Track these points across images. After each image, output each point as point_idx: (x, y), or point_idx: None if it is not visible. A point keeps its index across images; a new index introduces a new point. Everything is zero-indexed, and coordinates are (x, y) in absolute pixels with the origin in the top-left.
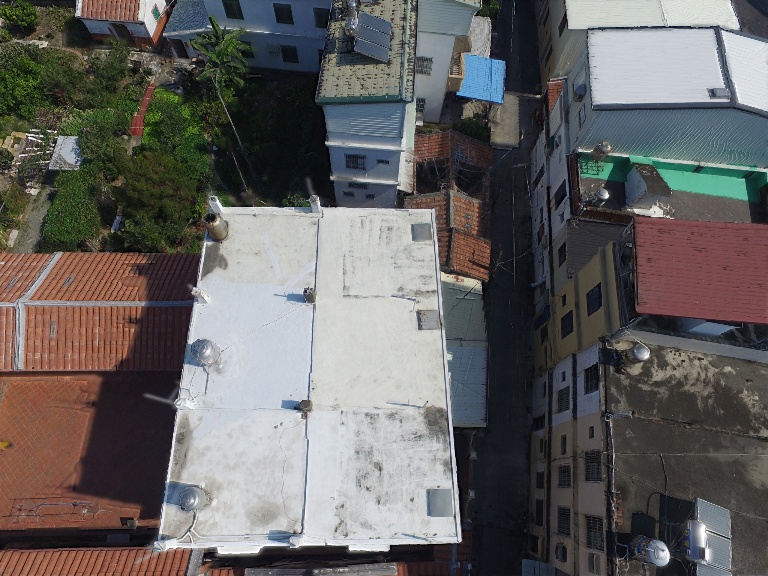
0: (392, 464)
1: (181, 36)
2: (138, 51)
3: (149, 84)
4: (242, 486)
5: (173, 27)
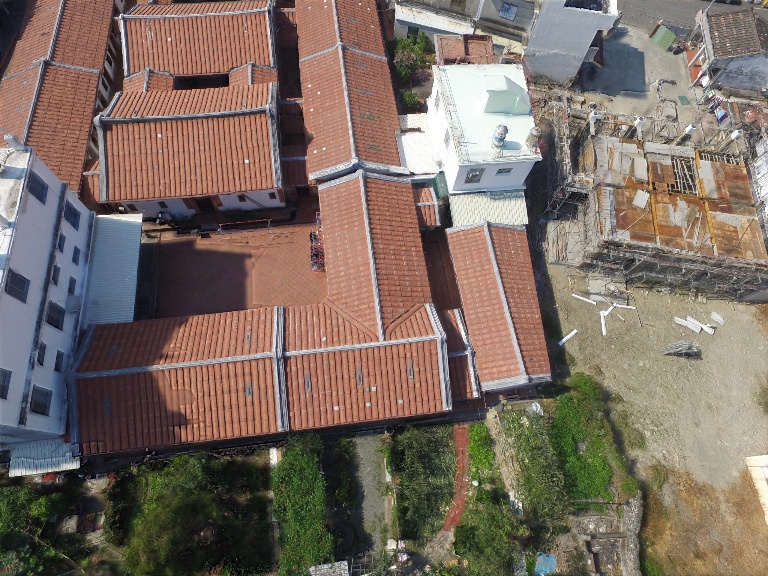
0: None
1: None
2: None
3: None
4: None
5: None
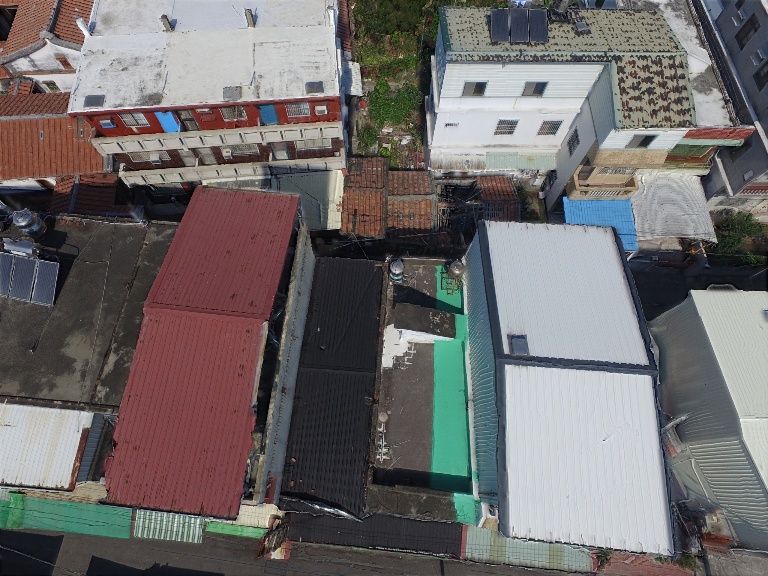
0: (125, 76)
1: None
2: None
3: None
4: (126, 8)
5: None
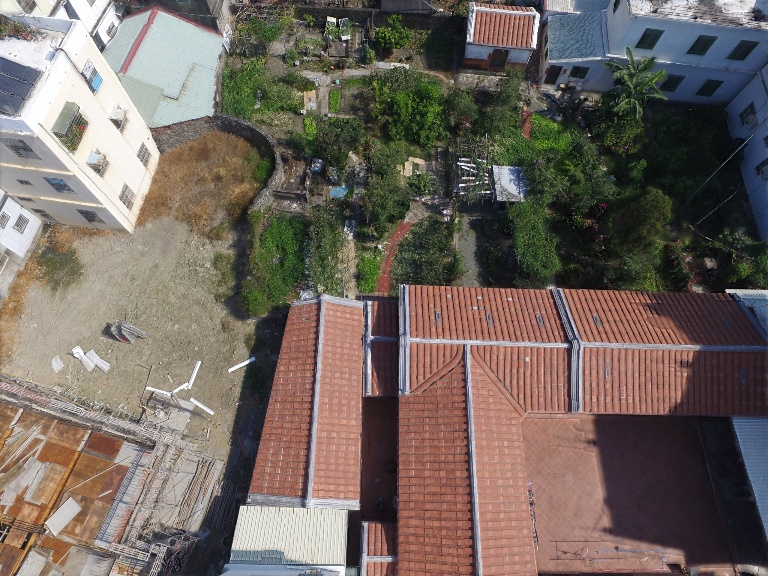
0: None
1: (568, 63)
2: (504, 76)
3: (523, 110)
4: None
5: (558, 54)
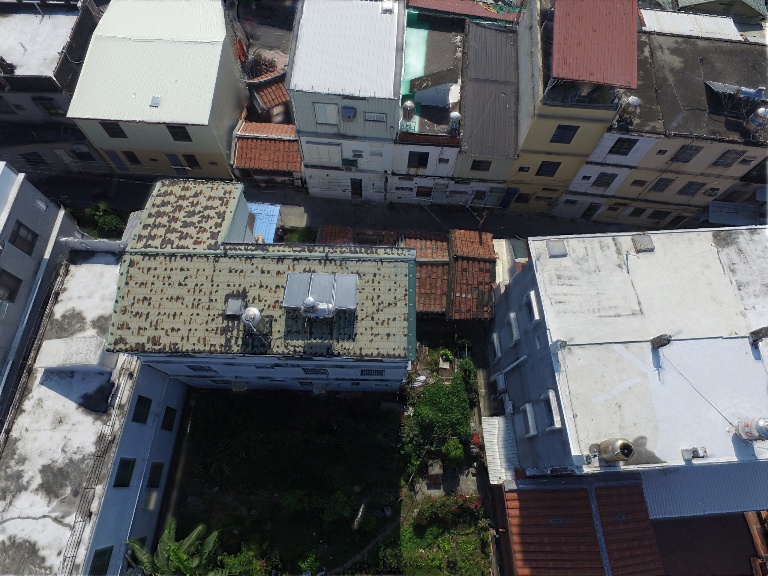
0: None
1: None
2: None
3: None
4: None
5: None
